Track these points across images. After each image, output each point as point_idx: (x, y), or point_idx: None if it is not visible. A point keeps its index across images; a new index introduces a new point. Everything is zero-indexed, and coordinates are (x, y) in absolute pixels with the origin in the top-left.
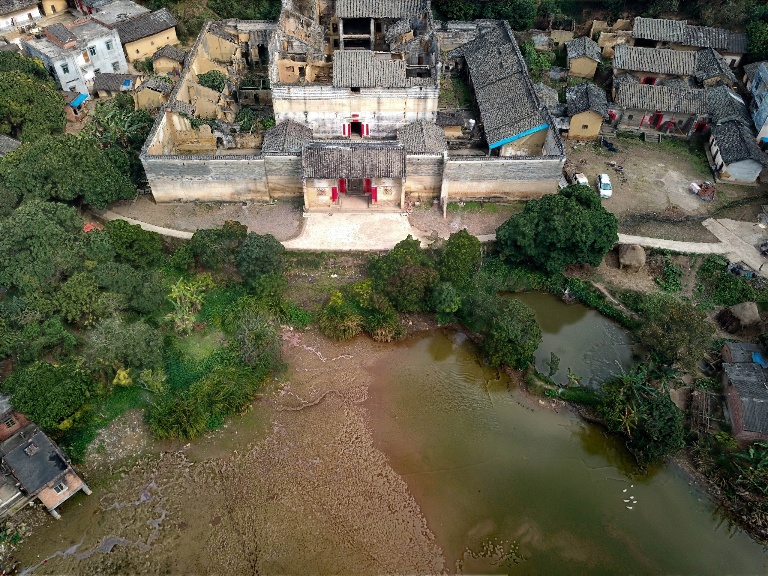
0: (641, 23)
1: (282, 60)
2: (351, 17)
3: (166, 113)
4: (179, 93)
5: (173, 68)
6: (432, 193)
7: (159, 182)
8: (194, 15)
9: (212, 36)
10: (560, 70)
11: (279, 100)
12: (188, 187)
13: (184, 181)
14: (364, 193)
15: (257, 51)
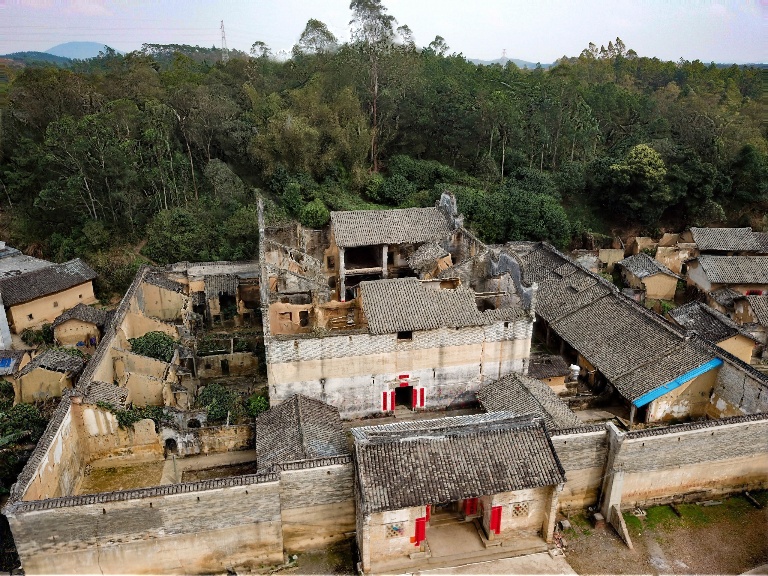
0: (700, 234)
1: (273, 304)
2: (357, 245)
3: (71, 406)
4: (97, 369)
5: (86, 335)
6: (583, 499)
7: (45, 557)
8: (122, 265)
9: (150, 286)
10: (634, 292)
11: (278, 364)
12: (111, 558)
13: (103, 547)
14: (463, 516)
15: (218, 302)
